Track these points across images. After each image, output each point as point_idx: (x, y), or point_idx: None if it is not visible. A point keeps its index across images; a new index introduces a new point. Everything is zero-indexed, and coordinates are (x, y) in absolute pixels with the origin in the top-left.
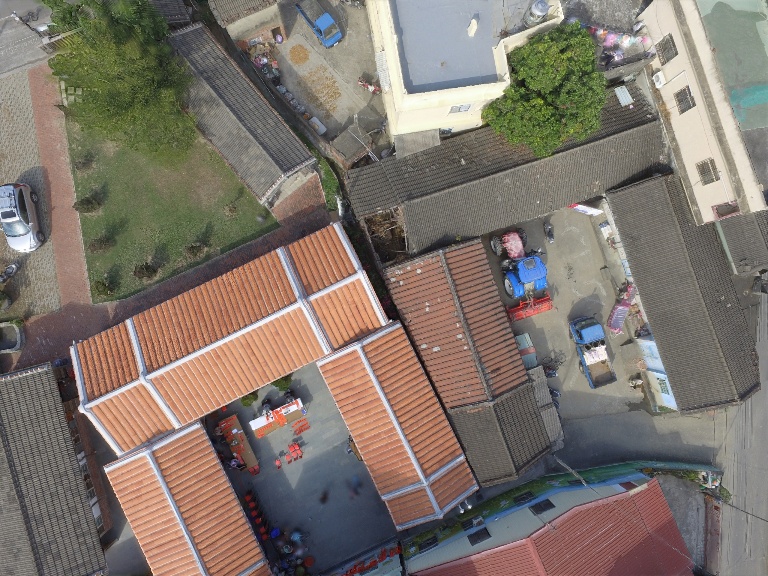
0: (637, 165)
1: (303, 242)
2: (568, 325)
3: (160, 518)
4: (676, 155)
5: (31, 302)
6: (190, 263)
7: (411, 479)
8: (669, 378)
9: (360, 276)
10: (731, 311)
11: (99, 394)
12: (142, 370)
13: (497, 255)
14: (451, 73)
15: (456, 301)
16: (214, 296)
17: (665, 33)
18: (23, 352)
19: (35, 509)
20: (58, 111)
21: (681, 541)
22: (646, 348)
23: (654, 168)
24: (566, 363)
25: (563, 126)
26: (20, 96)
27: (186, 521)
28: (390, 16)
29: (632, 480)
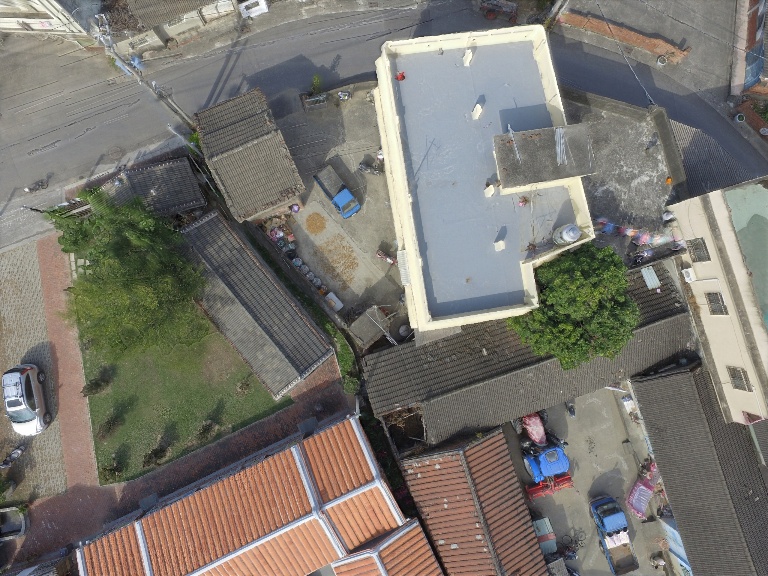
0: (664, 352)
1: (319, 438)
2: (589, 504)
3: None
4: (705, 349)
5: (36, 484)
6: (201, 442)
7: None
8: (694, 574)
9: (378, 486)
10: (759, 505)
11: None
12: None
13: (517, 433)
14: (477, 290)
15: (476, 503)
16: (226, 499)
17: (697, 235)
18: (27, 536)
19: None
20: (67, 284)
21: None
22: (669, 531)
23: (681, 354)
24: (586, 541)
25: (592, 348)
26: (28, 268)
27: None
28: (415, 239)
29: None
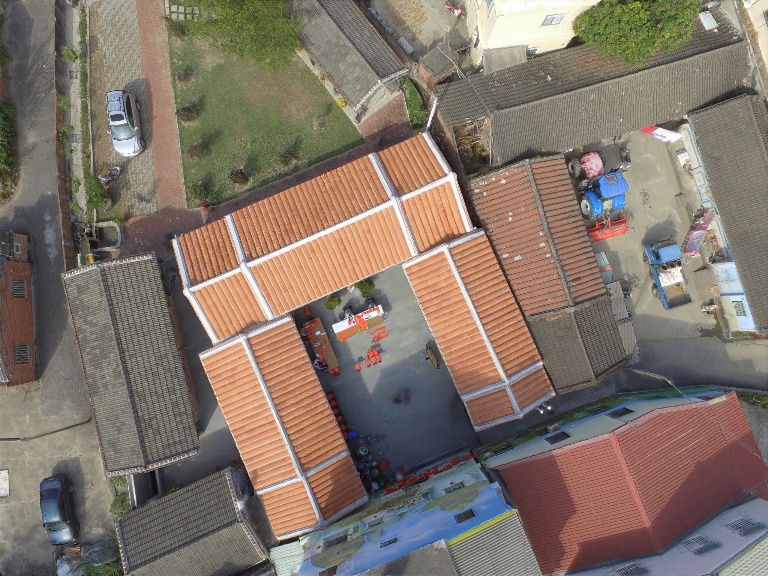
0: (720, 87)
1: (393, 149)
2: (643, 248)
3: (252, 403)
4: (762, 75)
5: (131, 205)
6: (279, 174)
7: (492, 379)
8: (747, 297)
9: (451, 178)
10: None
11: (201, 280)
12: (242, 259)
13: (575, 176)
14: None
15: (540, 209)
16: (309, 196)
17: None
18: (122, 251)
19: (138, 386)
20: (162, 27)
21: (758, 454)
22: (721, 272)
23: (737, 91)
24: (639, 286)
25: (659, 31)
26: (127, 13)
27: (277, 407)
28: None
29: (708, 395)
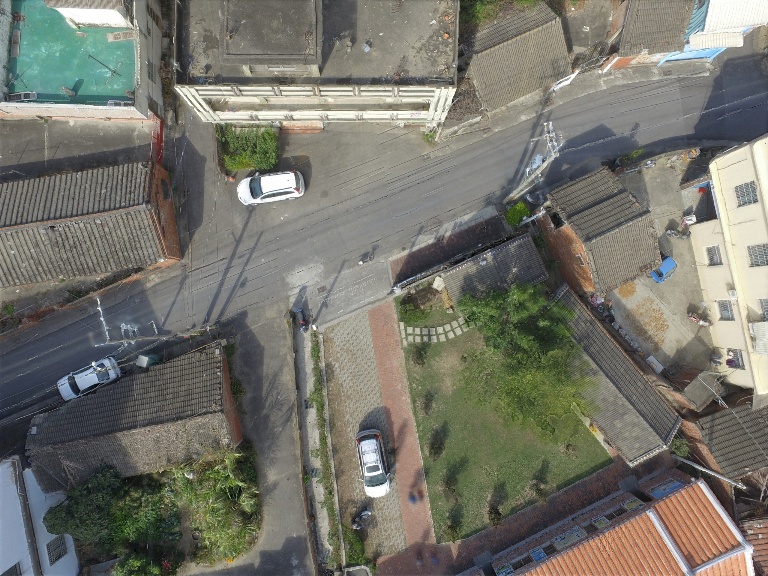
0: None
1: (670, 502)
2: None
3: None
4: None
5: (379, 543)
6: (528, 501)
7: None
8: None
9: (749, 551)
10: None
11: None
12: None
13: None
14: None
15: None
16: (591, 562)
17: None
18: None
19: None
20: (398, 351)
21: None
22: None
23: None
24: None
25: None
26: (361, 337)
27: None
28: None
29: None
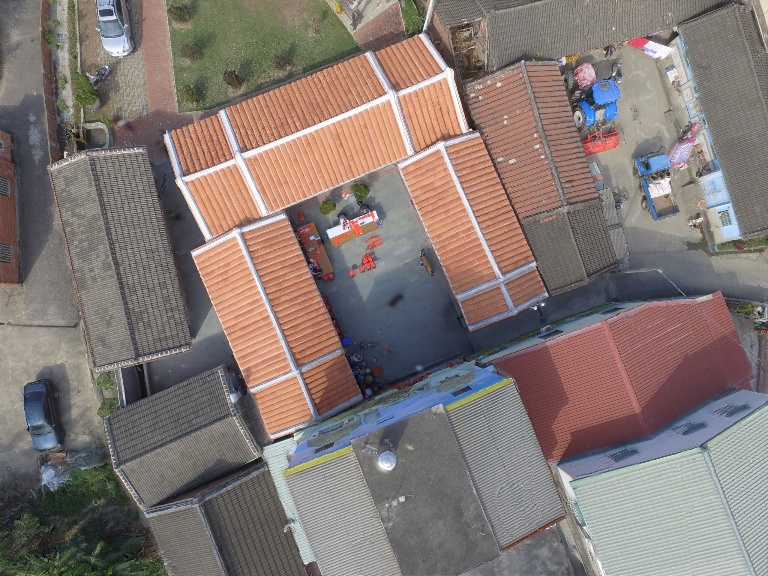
0: None
1: (390, 49)
2: (633, 161)
3: (245, 299)
4: None
5: (120, 107)
6: (273, 80)
7: (487, 276)
8: (733, 203)
9: (448, 73)
10: None
11: (195, 171)
12: (237, 150)
13: (568, 89)
14: None
15: (535, 110)
16: (305, 92)
17: None
18: None
19: (129, 278)
20: None
21: (743, 352)
22: (708, 185)
23: (725, 4)
24: (629, 200)
25: None
26: None
27: (271, 302)
28: None
29: None
